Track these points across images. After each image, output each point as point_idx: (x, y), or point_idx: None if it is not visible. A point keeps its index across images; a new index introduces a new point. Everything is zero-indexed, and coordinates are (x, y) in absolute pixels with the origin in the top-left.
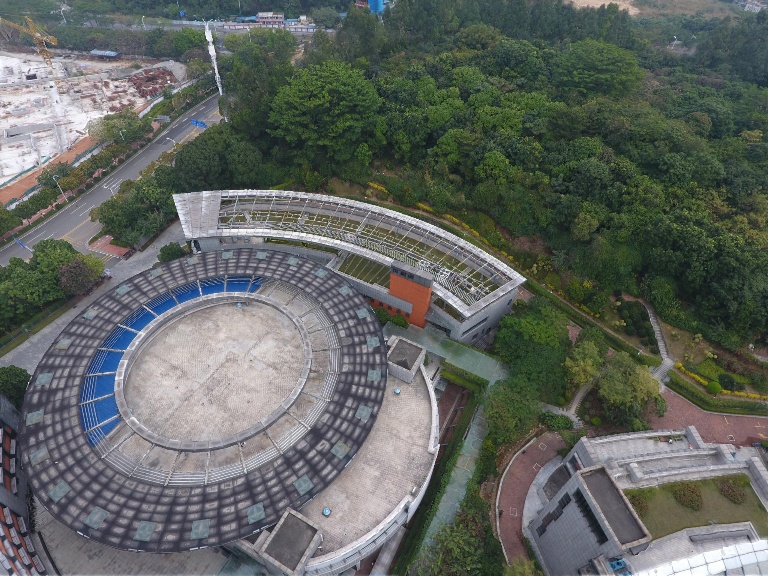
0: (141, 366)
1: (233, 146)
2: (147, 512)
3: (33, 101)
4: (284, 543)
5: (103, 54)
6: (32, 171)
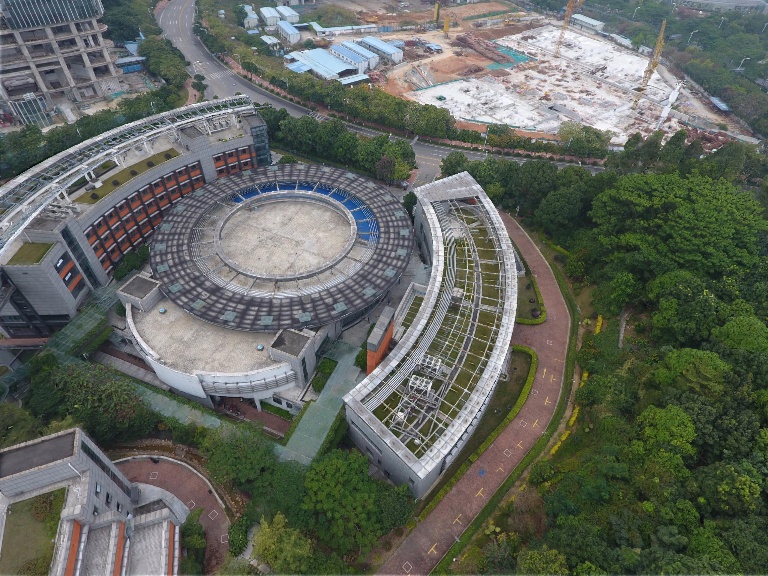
0: (292, 205)
1: (563, 187)
2: (178, 225)
3: (605, 101)
4: (140, 285)
5: (717, 104)
6: (514, 128)
